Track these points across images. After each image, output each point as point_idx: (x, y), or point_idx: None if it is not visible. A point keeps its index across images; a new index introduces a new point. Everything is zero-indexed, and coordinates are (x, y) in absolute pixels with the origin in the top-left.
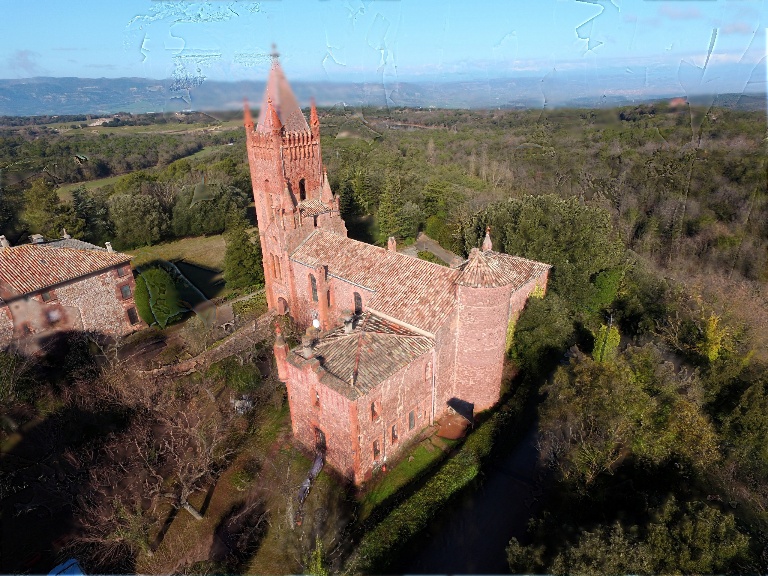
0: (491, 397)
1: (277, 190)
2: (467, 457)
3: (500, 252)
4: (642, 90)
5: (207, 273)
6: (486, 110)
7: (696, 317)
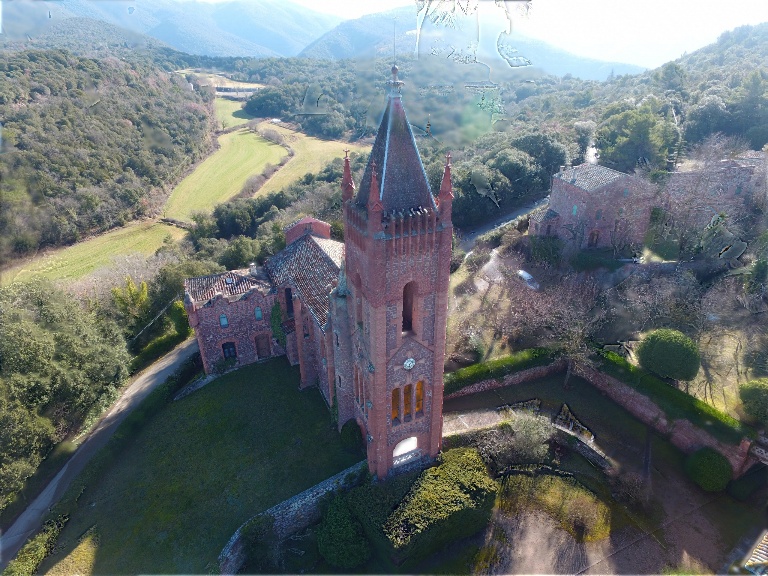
0: None
1: None
2: None
3: (45, 418)
4: None
5: None
6: None
7: None
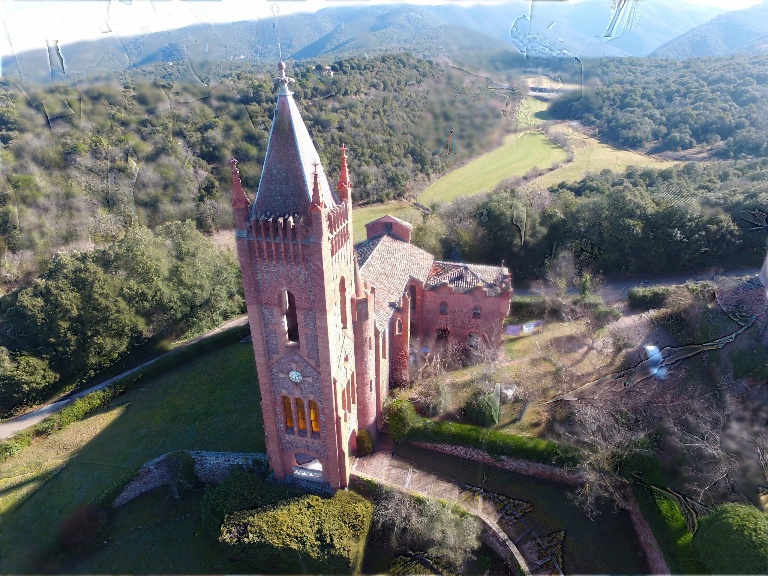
0: None
1: (350, 278)
2: None
3: (142, 317)
4: None
5: None
6: None
7: None
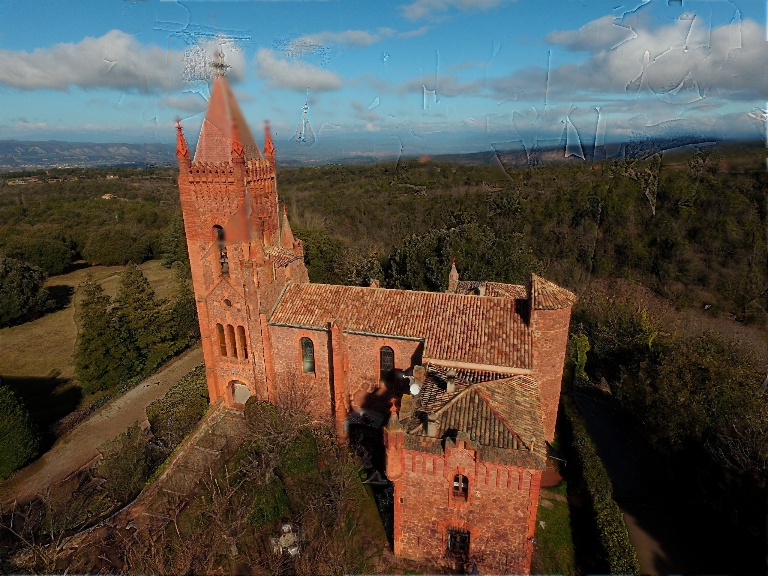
0: (554, 427)
1: None
2: (605, 497)
3: (427, 287)
4: (486, 135)
5: (25, 381)
6: (340, 156)
7: (606, 316)
